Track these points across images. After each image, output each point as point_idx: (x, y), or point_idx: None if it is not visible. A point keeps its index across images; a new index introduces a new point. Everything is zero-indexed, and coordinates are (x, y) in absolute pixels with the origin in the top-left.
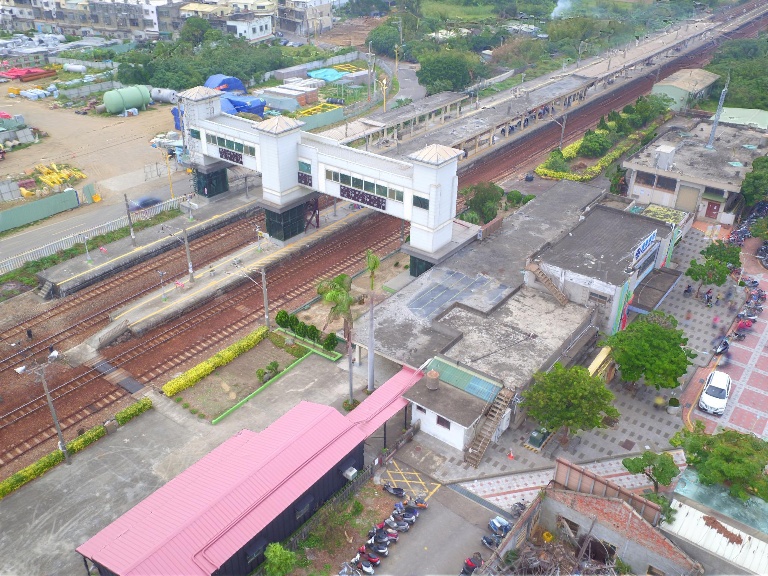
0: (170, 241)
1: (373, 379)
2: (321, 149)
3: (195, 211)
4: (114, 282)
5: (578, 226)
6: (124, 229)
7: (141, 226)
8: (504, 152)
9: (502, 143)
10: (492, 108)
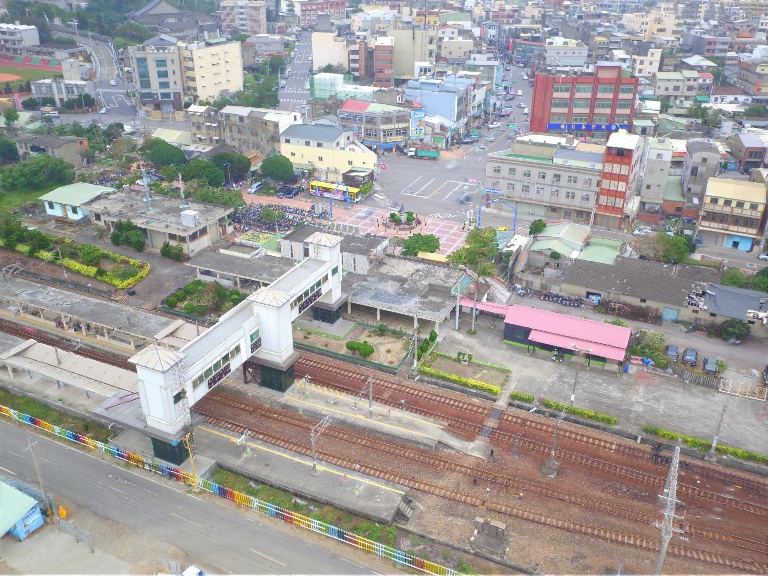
0: None
1: None
2: None
3: (221, 459)
4: (372, 474)
5: None
6: None
7: None
8: None
9: None
10: None
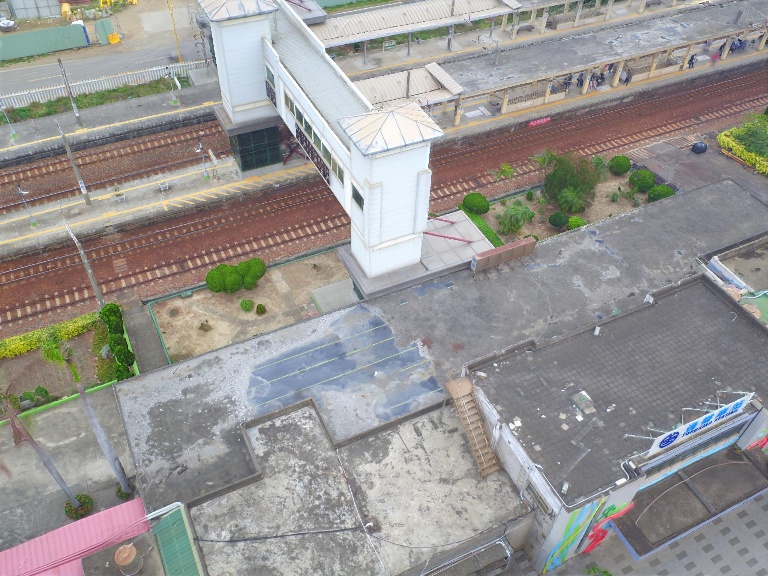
0: (125, 129)
1: (125, 480)
2: (295, 54)
3: (193, 88)
4: (26, 172)
5: (629, 314)
6: (100, 94)
7: (125, 93)
8: (703, 84)
9: (706, 69)
10: (717, 6)
